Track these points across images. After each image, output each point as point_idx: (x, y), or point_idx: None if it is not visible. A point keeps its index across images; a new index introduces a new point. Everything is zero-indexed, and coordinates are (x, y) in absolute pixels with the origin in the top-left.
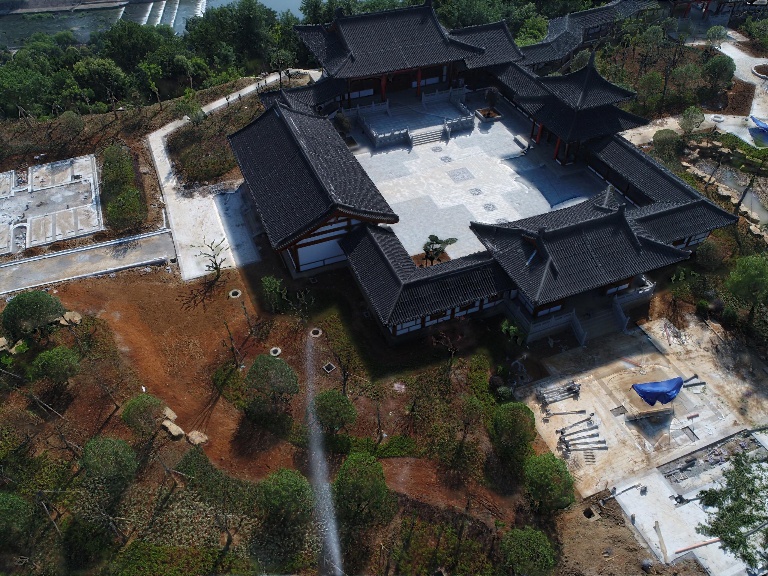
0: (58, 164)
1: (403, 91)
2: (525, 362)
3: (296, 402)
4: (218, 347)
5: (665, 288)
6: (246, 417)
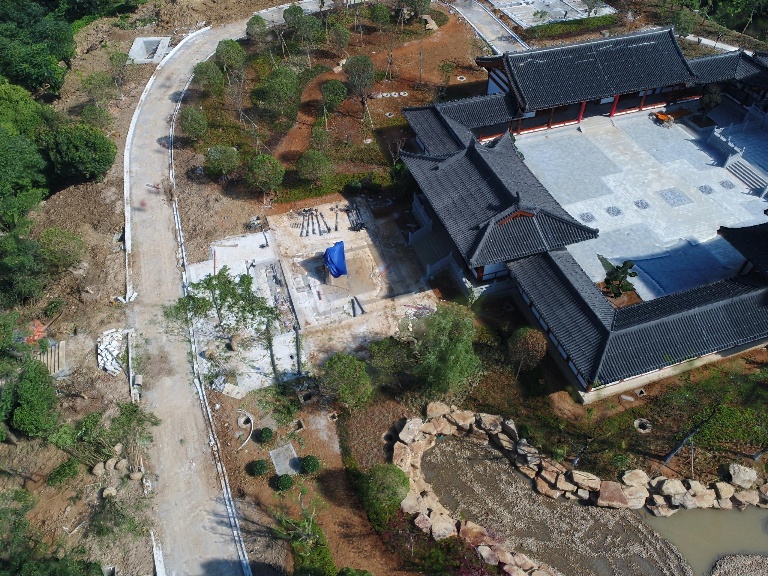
0: (600, 3)
1: None
2: (391, 207)
3: None
4: (407, 72)
5: (489, 323)
6: (349, 83)
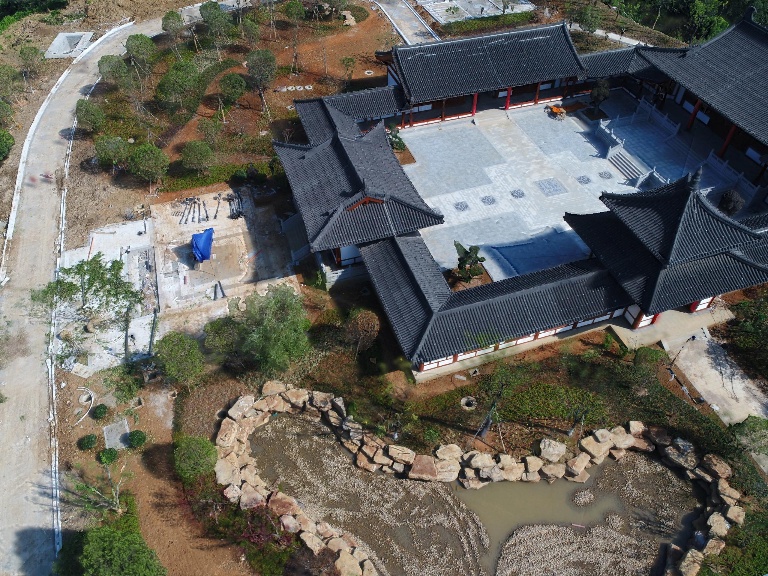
0: None
1: (733, 148)
2: (273, 196)
3: (263, 94)
4: (315, 66)
5: (342, 307)
6: None
